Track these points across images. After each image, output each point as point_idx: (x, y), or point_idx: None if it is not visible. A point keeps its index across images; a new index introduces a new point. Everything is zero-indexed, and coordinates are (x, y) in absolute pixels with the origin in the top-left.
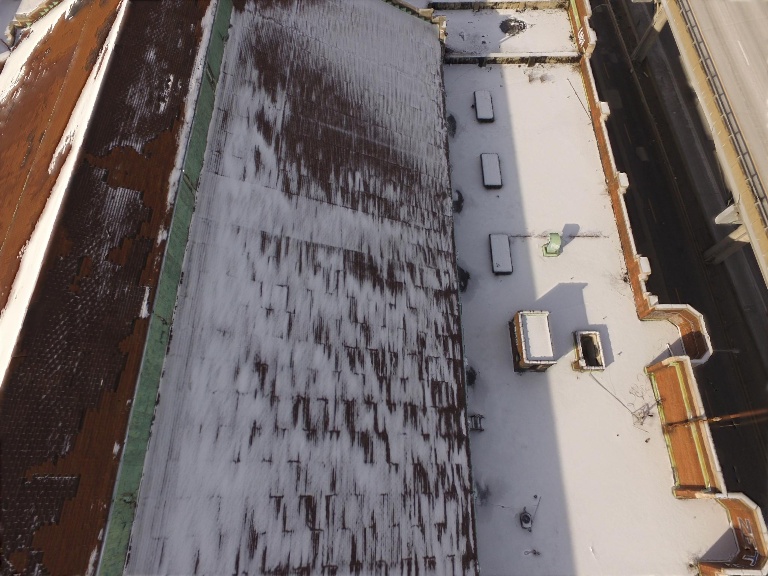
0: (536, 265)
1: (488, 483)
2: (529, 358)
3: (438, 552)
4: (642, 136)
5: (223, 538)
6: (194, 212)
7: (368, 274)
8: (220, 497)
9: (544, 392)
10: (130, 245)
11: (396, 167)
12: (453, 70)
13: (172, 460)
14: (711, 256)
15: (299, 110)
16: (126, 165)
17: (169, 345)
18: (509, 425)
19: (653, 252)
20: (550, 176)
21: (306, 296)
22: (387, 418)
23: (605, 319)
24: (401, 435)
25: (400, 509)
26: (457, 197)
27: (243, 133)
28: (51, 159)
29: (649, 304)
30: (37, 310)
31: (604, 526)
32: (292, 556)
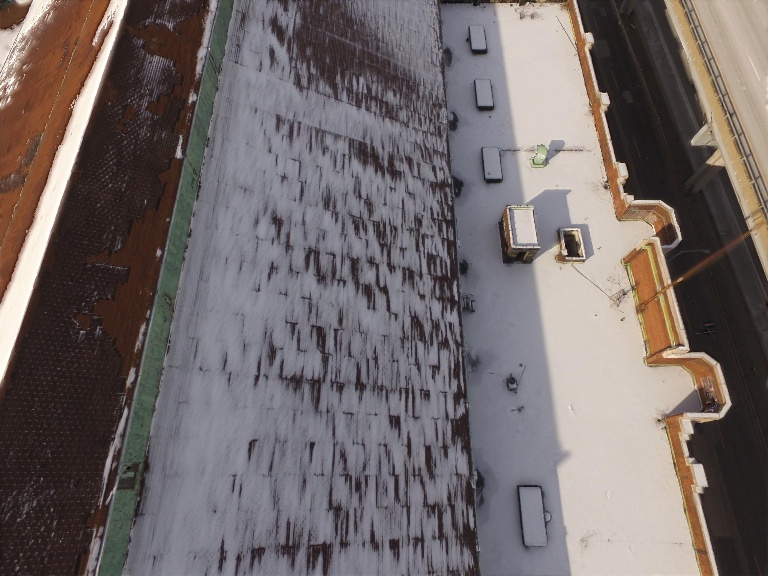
0: (524, 175)
1: (478, 354)
2: (516, 244)
3: (432, 388)
4: (628, 81)
5: (247, 347)
6: (217, 91)
7: (371, 161)
8: (244, 316)
9: (530, 280)
10: (166, 101)
11: (396, 77)
12: (449, 9)
13: (203, 281)
14: (690, 184)
15: (308, 20)
16: (160, 38)
17: (198, 193)
18: (498, 307)
19: (637, 183)
20: (538, 100)
21: (316, 171)
22: (388, 277)
23: (586, 220)
24: (400, 292)
25: (399, 349)
26: (452, 117)
27: (259, 33)
28: (94, 35)
29: (626, 202)
30: (91, 140)
31: (582, 389)
32: (305, 370)
